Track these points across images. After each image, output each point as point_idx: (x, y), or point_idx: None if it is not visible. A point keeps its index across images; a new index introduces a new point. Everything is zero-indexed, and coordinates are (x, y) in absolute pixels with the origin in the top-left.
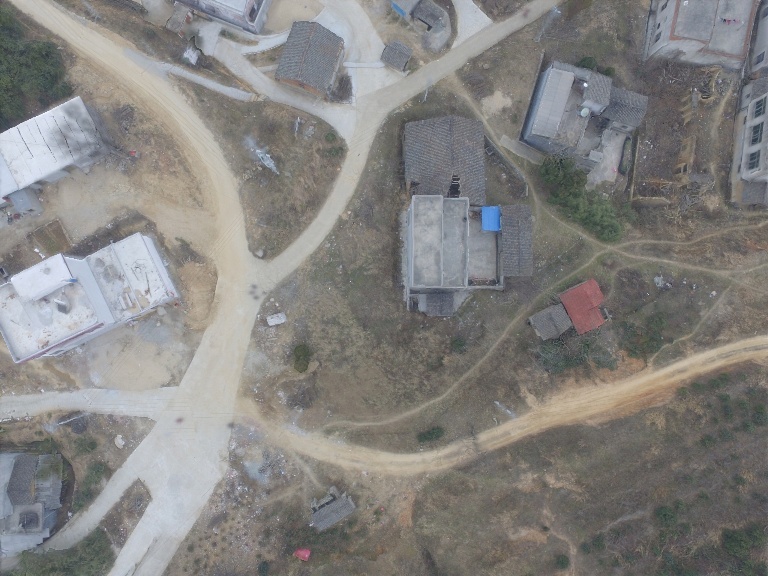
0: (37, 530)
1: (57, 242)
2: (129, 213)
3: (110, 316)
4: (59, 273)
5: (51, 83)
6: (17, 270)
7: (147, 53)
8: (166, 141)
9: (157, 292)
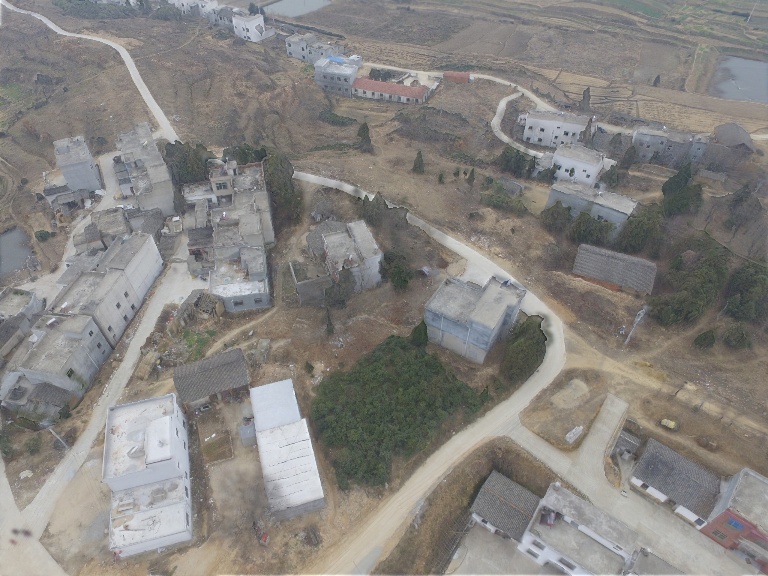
0: (7, 398)
1: (214, 453)
2: (216, 523)
3: (121, 488)
4: (155, 454)
5: (349, 473)
6: (204, 418)
7: (375, 572)
8: (276, 575)
9: (121, 538)
